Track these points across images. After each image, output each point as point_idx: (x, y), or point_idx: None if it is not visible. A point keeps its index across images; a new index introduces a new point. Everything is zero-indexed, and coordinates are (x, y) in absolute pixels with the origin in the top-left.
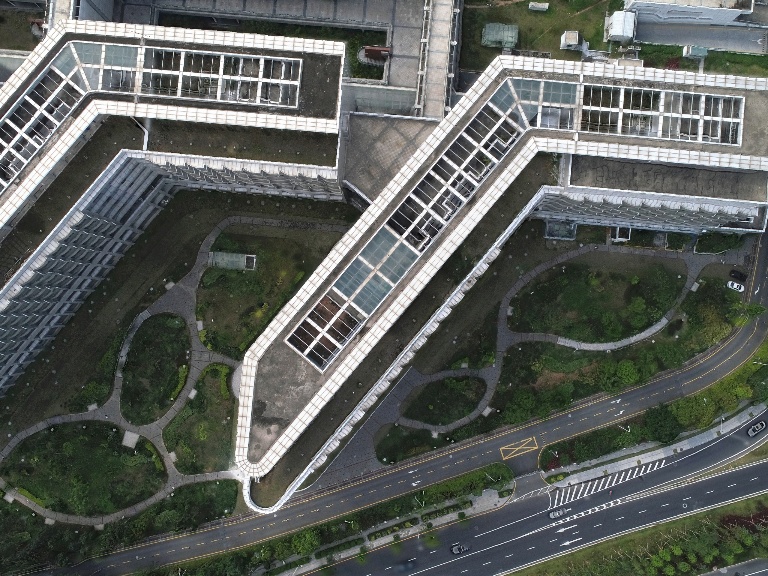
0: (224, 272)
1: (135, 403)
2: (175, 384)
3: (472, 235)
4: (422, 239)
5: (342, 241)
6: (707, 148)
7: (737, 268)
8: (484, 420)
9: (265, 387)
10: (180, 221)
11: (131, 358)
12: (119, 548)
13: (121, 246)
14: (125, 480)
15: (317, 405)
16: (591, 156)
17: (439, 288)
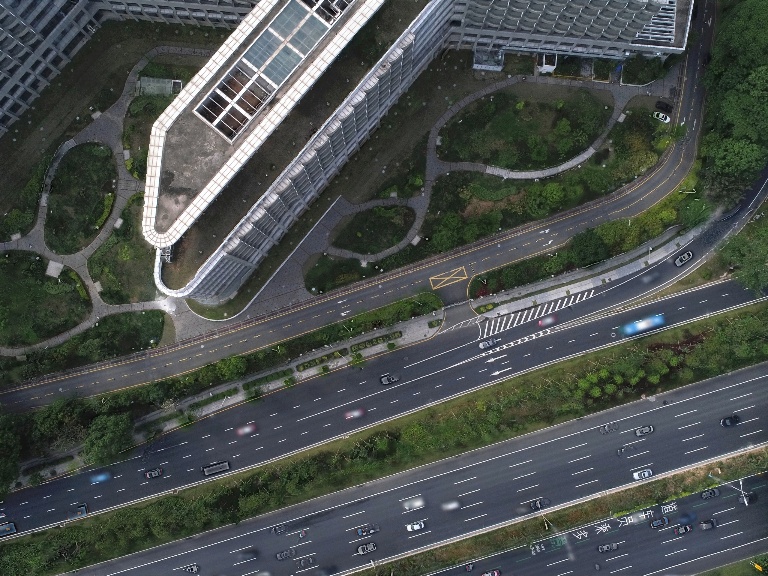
0: (151, 100)
1: (59, 231)
2: (100, 212)
3: (384, 14)
4: (333, 15)
5: (252, 13)
6: None
7: (663, 100)
8: (413, 248)
9: (173, 157)
10: (107, 51)
11: (56, 186)
12: (42, 380)
13: (45, 69)
14: (48, 309)
15: (226, 175)
16: None
17: (353, 71)
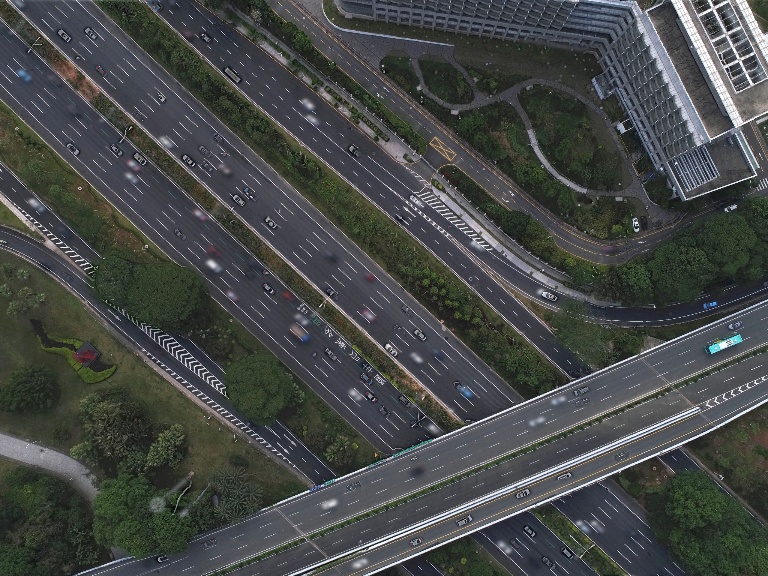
0: None
1: None
2: None
3: None
4: None
5: None
6: (722, 75)
7: (649, 219)
8: (448, 112)
9: None
10: None
11: None
12: None
13: None
14: None
15: None
16: (674, 7)
17: None
